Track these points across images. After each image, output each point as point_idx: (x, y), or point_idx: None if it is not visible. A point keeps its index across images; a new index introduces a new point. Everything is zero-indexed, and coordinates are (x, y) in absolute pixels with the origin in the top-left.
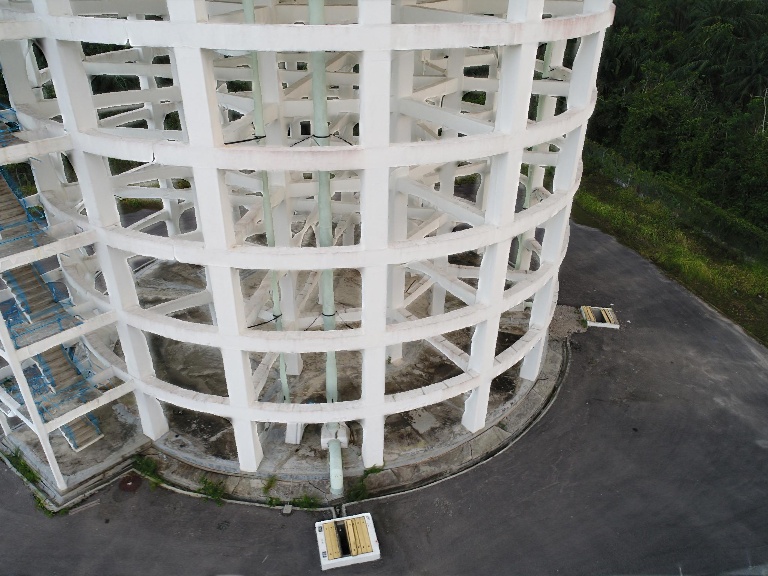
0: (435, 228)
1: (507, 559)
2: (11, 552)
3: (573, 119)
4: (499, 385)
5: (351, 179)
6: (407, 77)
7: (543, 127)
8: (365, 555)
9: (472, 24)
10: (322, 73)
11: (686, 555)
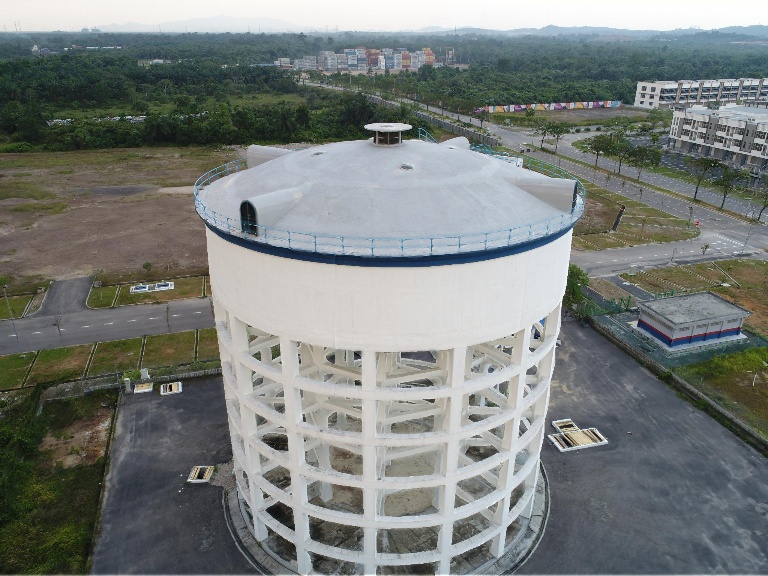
0: None
1: None
2: None
3: None
4: None
5: None
6: None
7: None
8: None
9: None
10: None
11: None
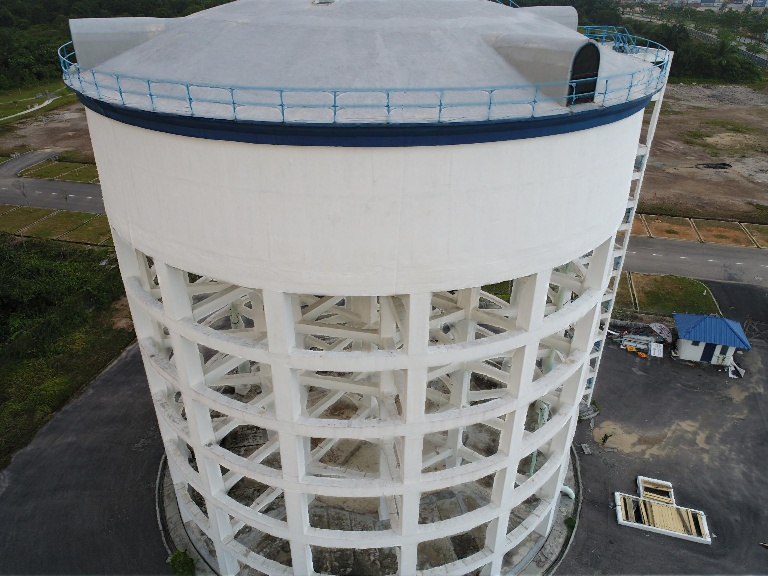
0: None
1: None
2: None
3: None
4: None
5: None
6: None
7: None
8: None
9: None
10: None
11: None
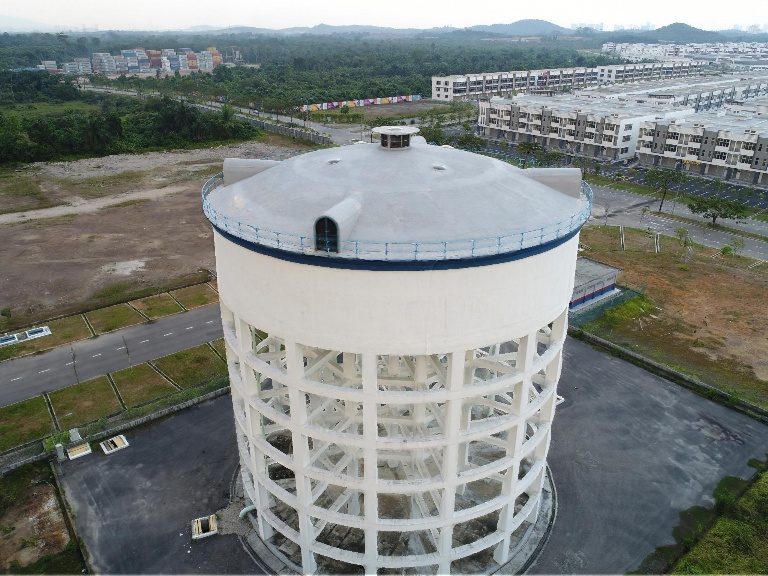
0: None
1: None
2: None
3: None
4: None
5: None
6: None
7: None
8: None
9: None
10: None
11: (199, 414)
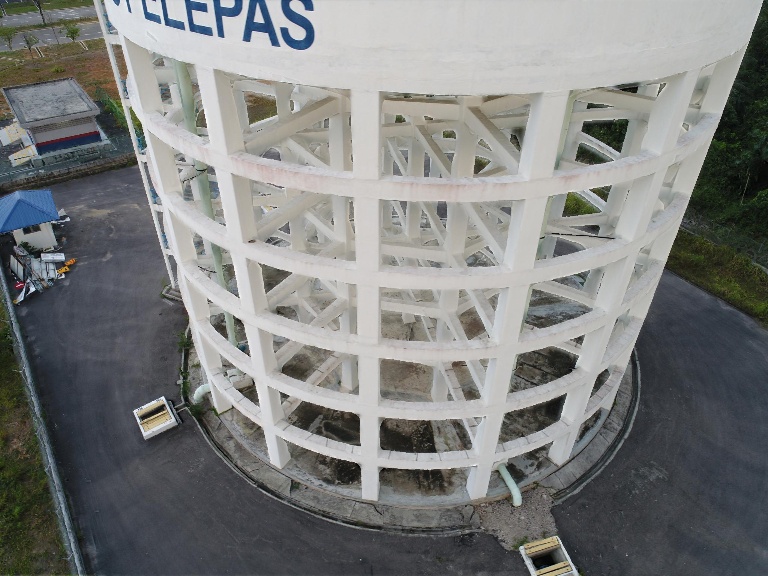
0: (416, 313)
1: (153, 516)
2: (138, 293)
3: (321, 268)
4: (345, 470)
5: (318, 219)
6: (338, 158)
7: (264, 251)
8: (142, 429)
9: (177, 134)
10: (190, 126)
11: None
